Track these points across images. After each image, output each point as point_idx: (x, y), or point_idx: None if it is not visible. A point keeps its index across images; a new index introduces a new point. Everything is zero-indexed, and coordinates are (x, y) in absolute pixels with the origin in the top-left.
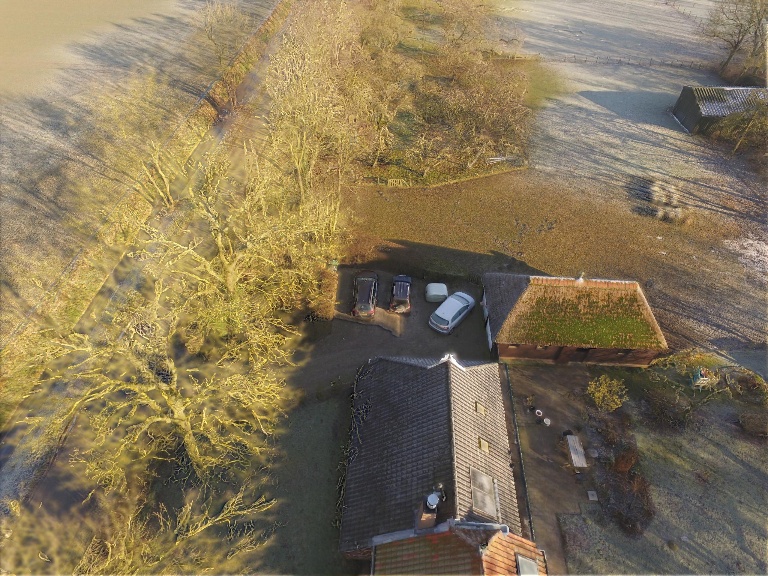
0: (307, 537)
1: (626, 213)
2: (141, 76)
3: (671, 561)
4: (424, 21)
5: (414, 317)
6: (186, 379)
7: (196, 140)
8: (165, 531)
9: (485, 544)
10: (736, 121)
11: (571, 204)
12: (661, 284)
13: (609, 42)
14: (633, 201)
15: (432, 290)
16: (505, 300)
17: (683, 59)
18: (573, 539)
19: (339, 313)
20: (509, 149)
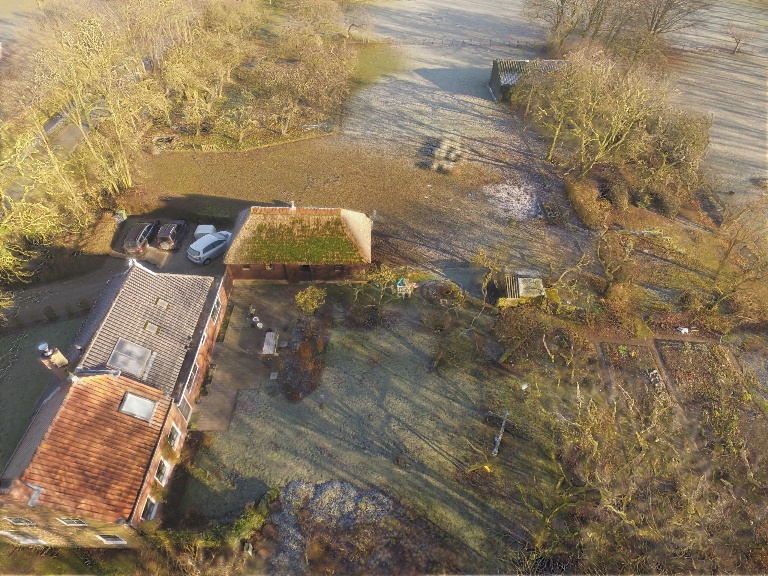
0: (19, 416)
1: (408, 167)
2: (4, 64)
3: (316, 417)
4: (293, 10)
5: (181, 253)
6: None
7: (42, 119)
8: None
9: (68, 372)
10: (520, 87)
11: (363, 161)
12: (412, 221)
13: (463, 26)
14: (419, 157)
15: (199, 230)
16: (237, 229)
17: (523, 40)
18: (242, 405)
19: (115, 253)
20: (315, 116)
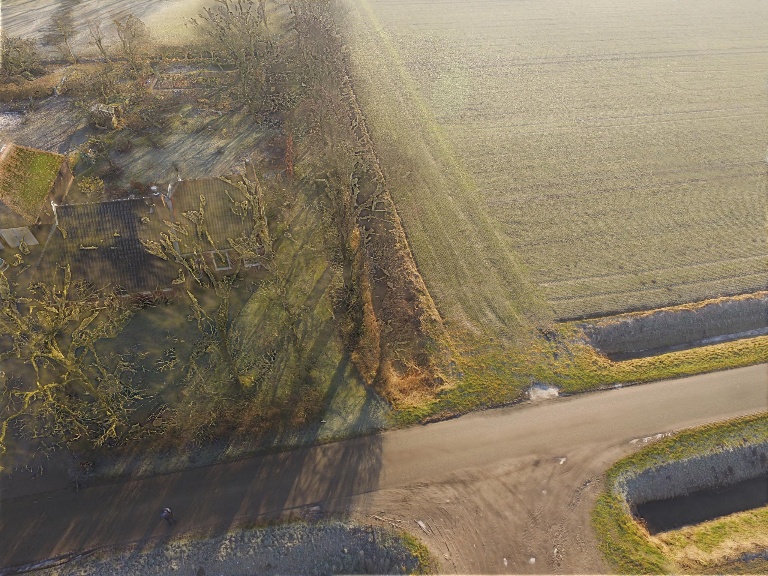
0: (176, 317)
1: None
2: None
3: None
4: None
5: None
6: (5, 465)
7: None
8: (170, 405)
9: None
10: None
11: None
12: None
13: None
14: None
15: None
16: None
17: None
18: None
19: None
20: None
